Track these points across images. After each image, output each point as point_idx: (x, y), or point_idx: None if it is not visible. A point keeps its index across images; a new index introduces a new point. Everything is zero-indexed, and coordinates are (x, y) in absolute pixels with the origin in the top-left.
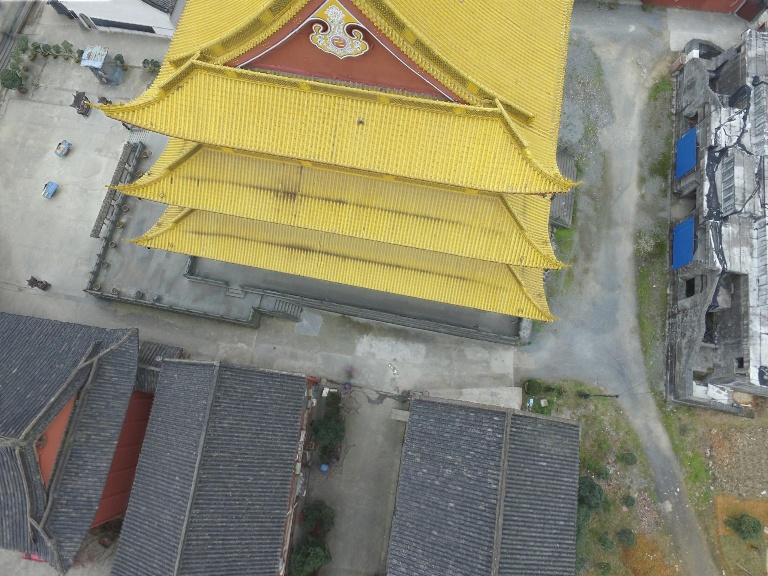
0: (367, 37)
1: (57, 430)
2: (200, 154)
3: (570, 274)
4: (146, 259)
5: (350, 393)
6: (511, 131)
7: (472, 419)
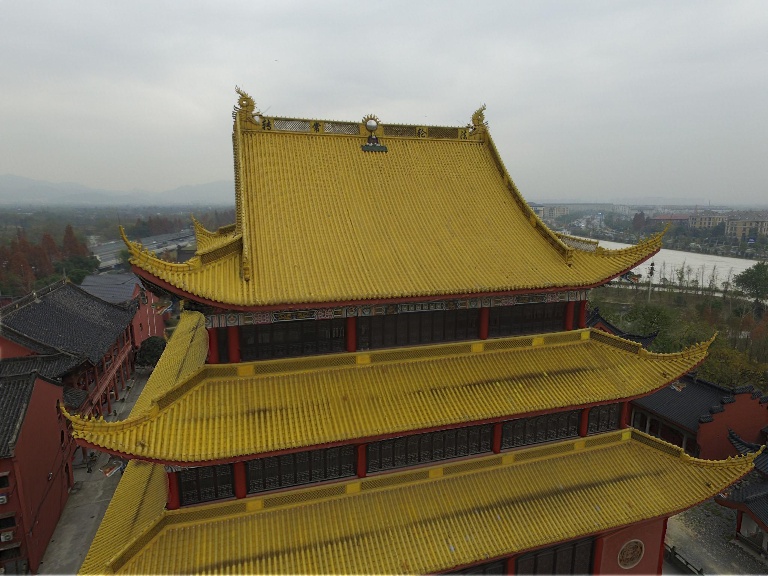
0: None
1: (2, 351)
2: None
3: None
4: None
5: None
6: None
7: None
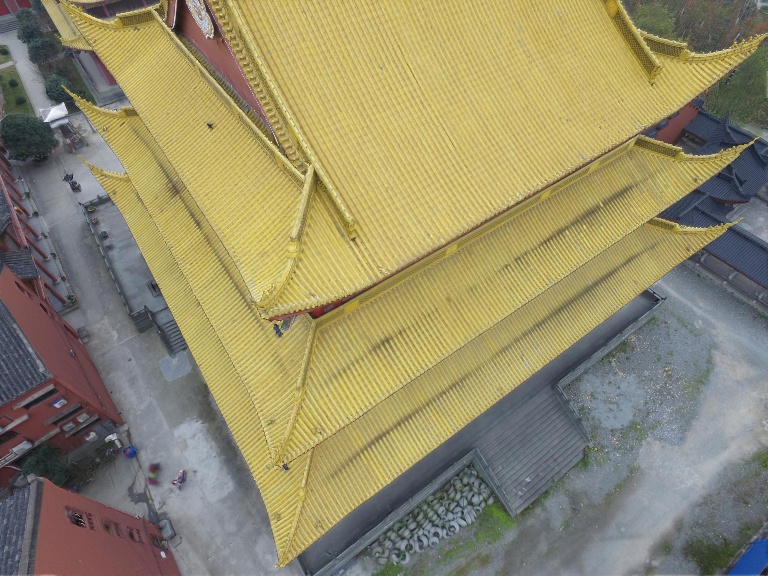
0: None
1: None
2: None
3: (462, 573)
4: None
5: (113, 456)
6: None
7: (8, 563)
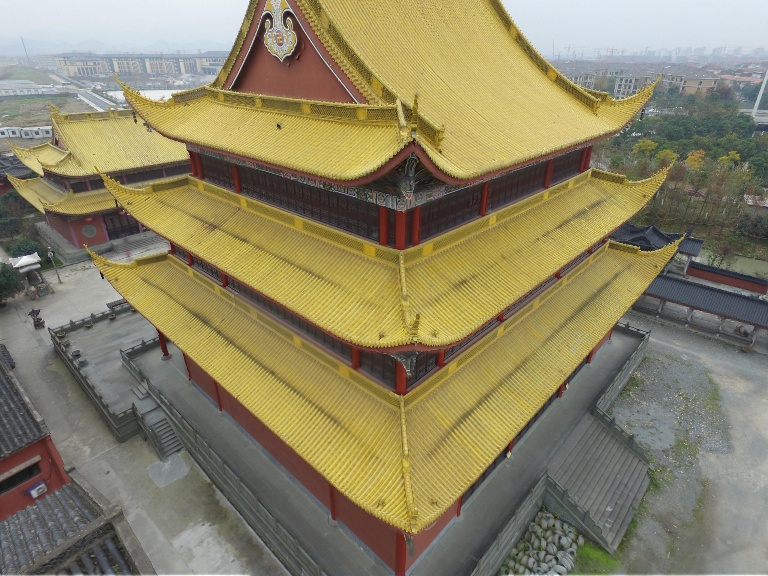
0: (297, 29)
1: None
2: (184, 190)
3: None
4: (118, 336)
5: None
6: (399, 124)
7: (64, 525)
